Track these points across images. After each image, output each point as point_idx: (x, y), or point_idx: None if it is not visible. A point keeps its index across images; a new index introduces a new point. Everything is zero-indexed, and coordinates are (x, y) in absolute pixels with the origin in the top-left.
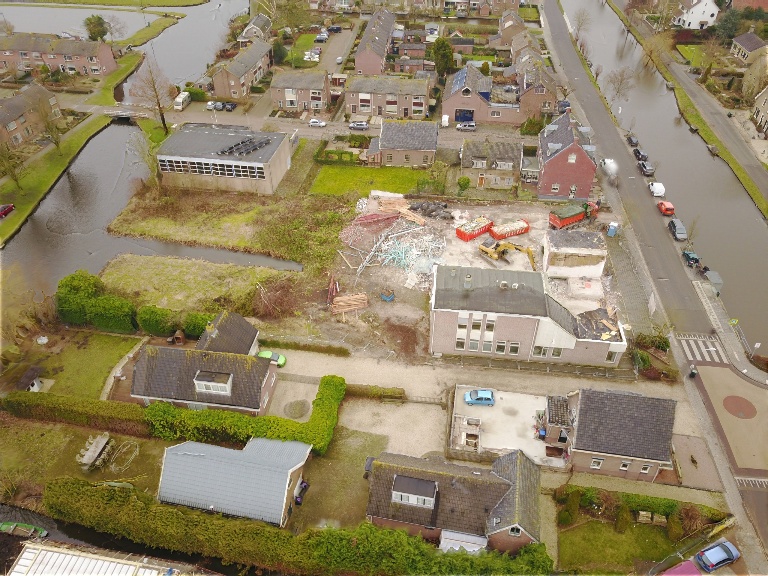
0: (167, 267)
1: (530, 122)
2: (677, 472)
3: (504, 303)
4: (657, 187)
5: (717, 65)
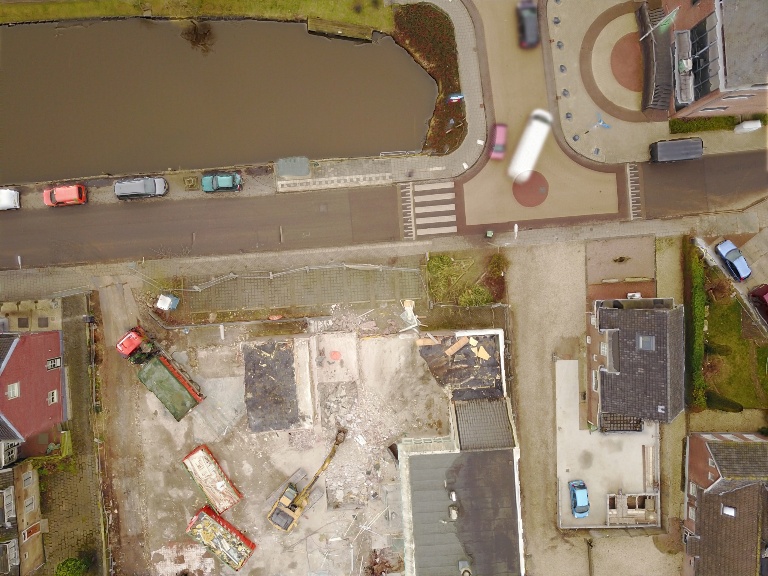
0: None
1: None
2: (642, 282)
3: (493, 510)
4: (3, 203)
5: None
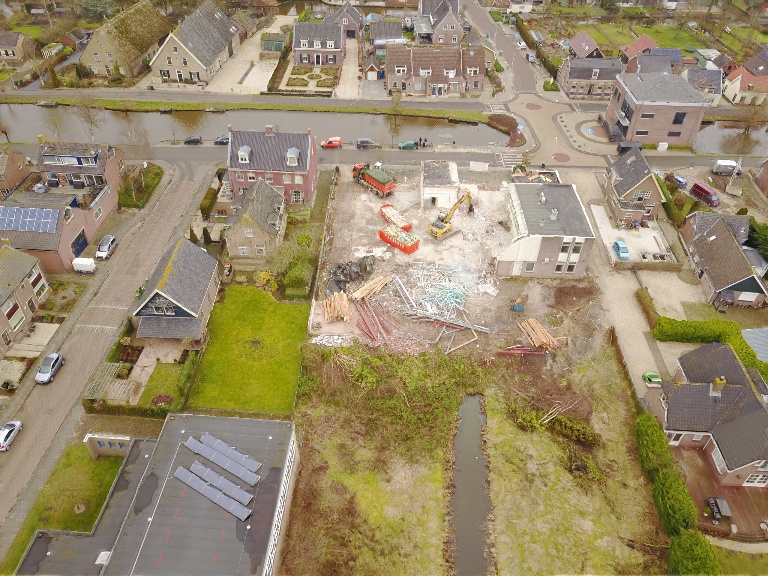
0: (529, 569)
1: (121, 195)
2: None
3: (566, 202)
4: None
5: (3, 73)
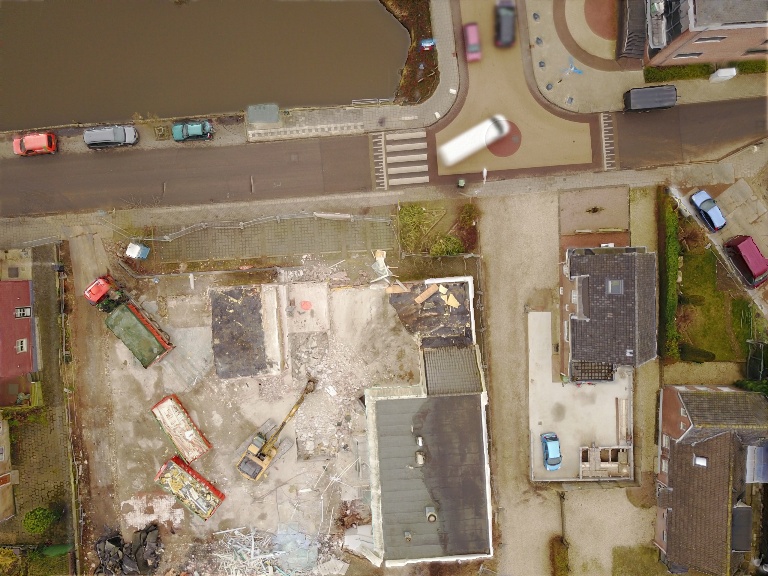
0: None
1: None
2: (615, 233)
3: (460, 456)
4: None
5: None
